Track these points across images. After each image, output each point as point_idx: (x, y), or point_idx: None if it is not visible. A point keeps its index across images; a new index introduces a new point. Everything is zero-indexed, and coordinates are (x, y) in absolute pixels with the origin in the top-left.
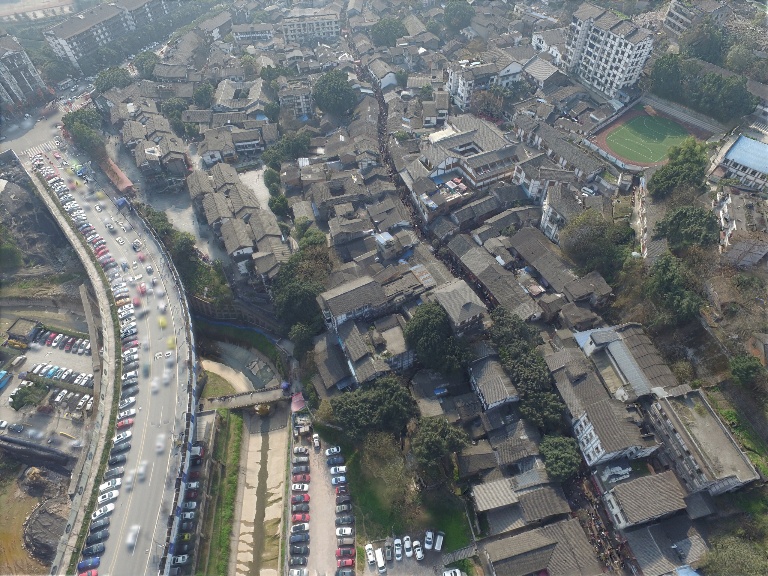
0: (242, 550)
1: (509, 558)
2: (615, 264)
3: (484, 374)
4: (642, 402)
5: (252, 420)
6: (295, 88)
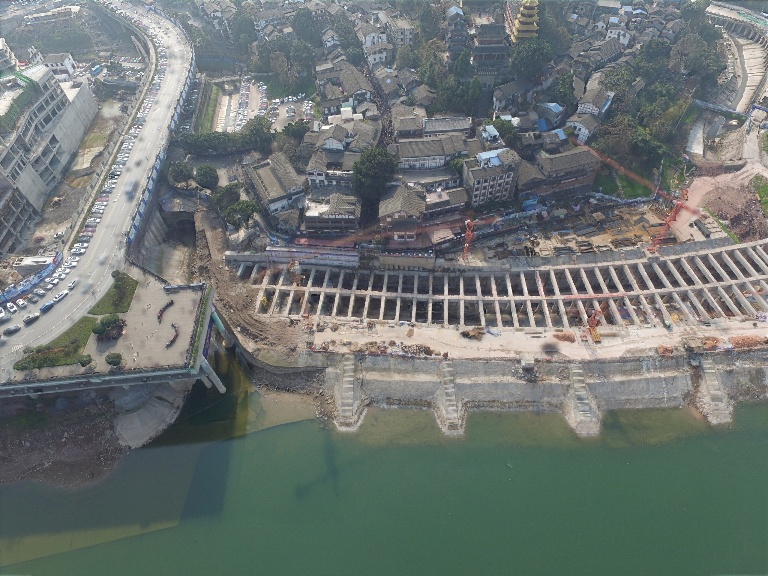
0: (219, 123)
1: (323, 72)
2: None
3: None
4: (386, 28)
5: (224, 92)
6: None
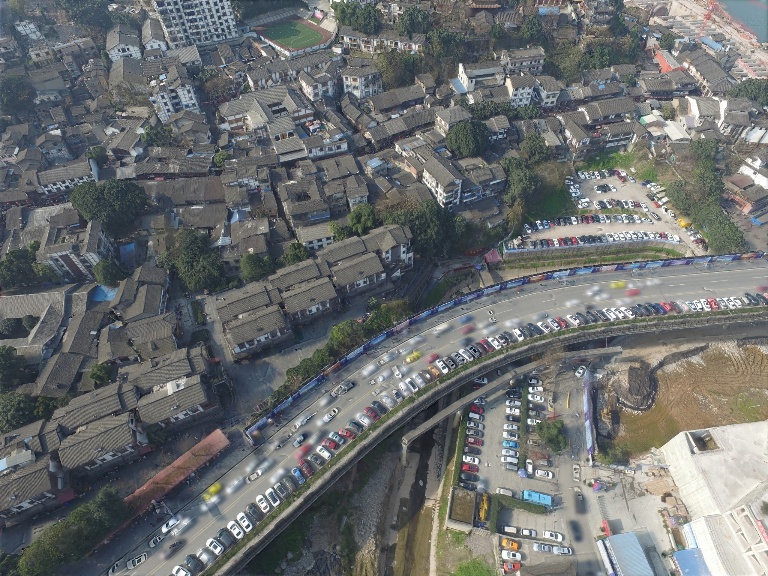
0: None
1: None
2: (411, 68)
3: (490, 127)
4: None
5: None
6: (78, 239)
